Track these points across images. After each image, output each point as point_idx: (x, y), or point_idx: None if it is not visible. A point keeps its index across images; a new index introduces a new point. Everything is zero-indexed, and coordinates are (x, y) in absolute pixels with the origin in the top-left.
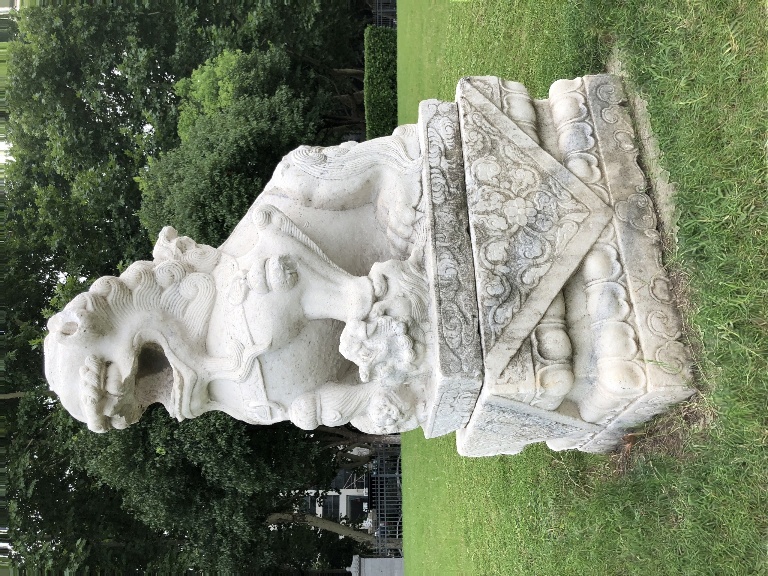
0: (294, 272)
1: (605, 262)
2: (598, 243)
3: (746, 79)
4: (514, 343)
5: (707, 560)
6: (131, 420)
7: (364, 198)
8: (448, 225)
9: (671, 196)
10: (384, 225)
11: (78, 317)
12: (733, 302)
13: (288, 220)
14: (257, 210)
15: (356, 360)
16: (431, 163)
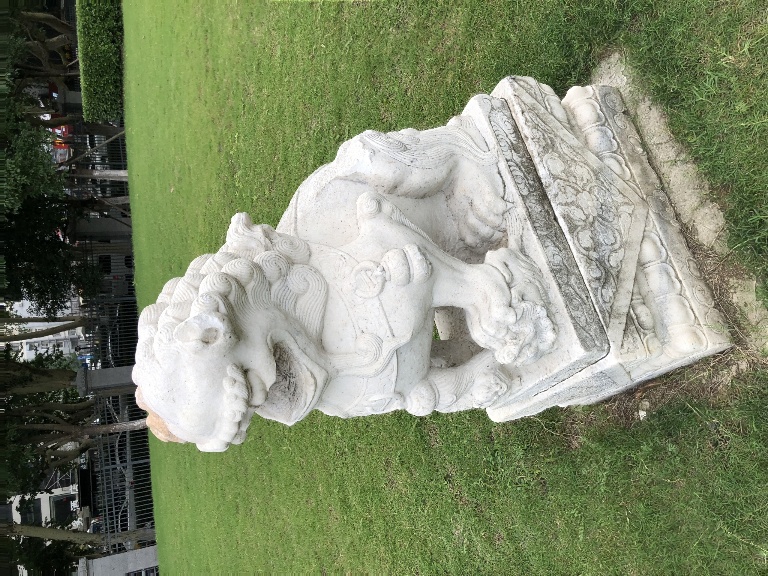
0: None
1: (655, 247)
2: (646, 231)
3: None
4: (622, 318)
5: None
6: None
7: (440, 186)
8: (540, 215)
9: (692, 193)
10: (459, 213)
11: (221, 322)
12: None
13: (397, 209)
14: (368, 198)
15: (495, 344)
16: (506, 156)
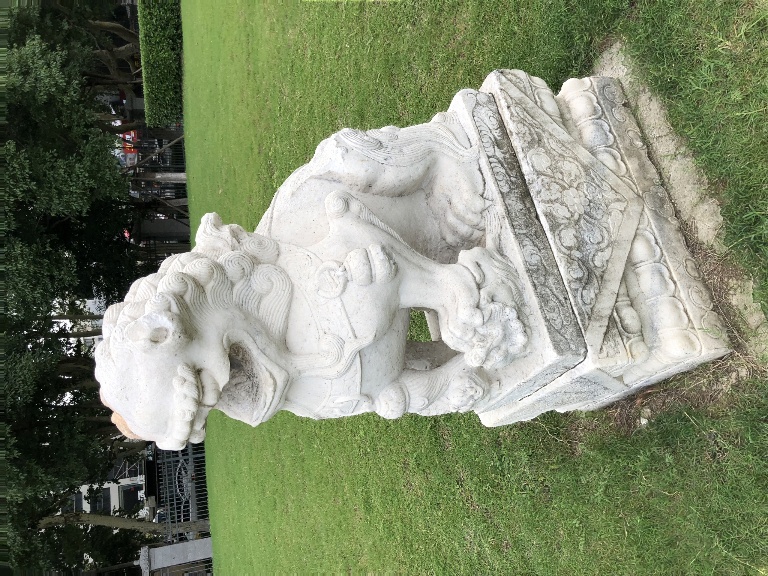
0: (395, 262)
1: (649, 246)
2: (639, 229)
3: None
4: (603, 321)
5: (766, 484)
6: None
7: (418, 185)
8: (520, 213)
9: (691, 189)
10: (439, 212)
11: (170, 321)
12: None
13: (366, 207)
14: (335, 197)
15: (463, 346)
16: (487, 152)
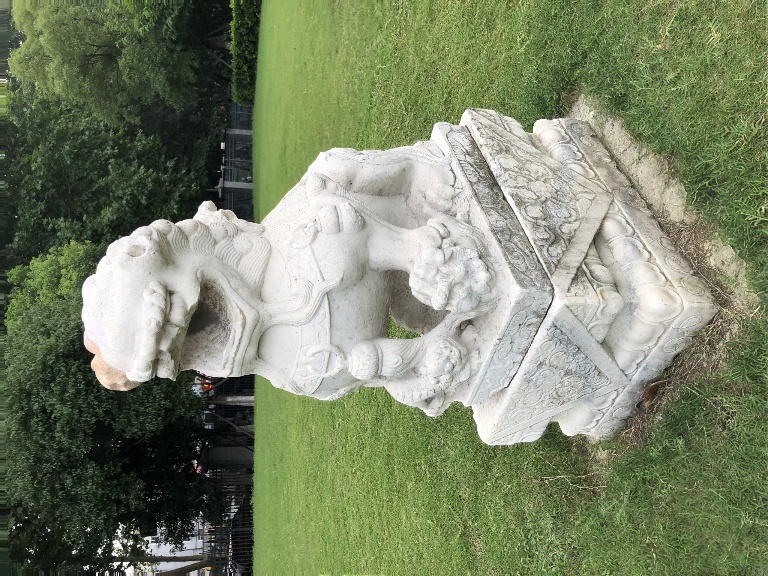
0: (362, 216)
1: (619, 225)
2: (609, 213)
3: (731, 51)
4: (571, 270)
5: None
6: (175, 371)
7: (397, 187)
8: (487, 195)
9: (657, 180)
10: (417, 209)
11: (147, 240)
12: (762, 191)
13: (342, 187)
14: (313, 176)
15: (429, 290)
16: (458, 158)
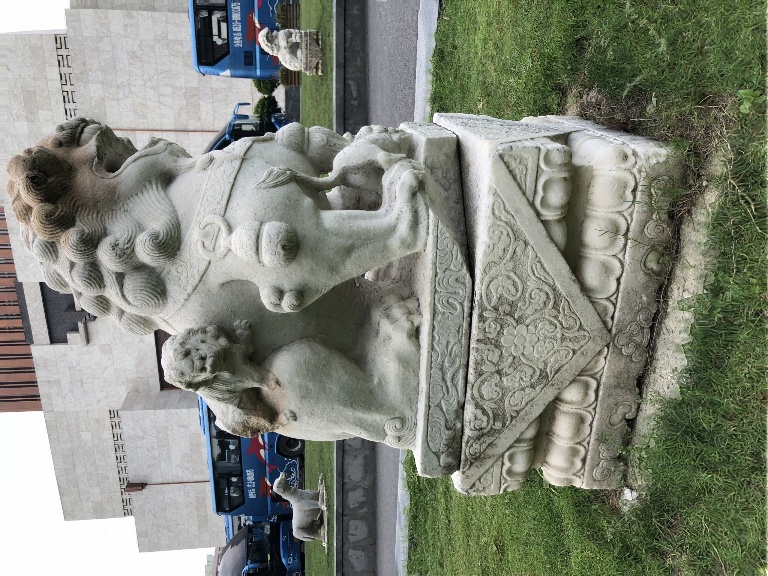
0: None
1: None
2: None
3: None
4: None
5: None
6: (102, 137)
7: None
8: None
9: None
10: None
11: None
12: None
13: None
14: None
15: None
16: None
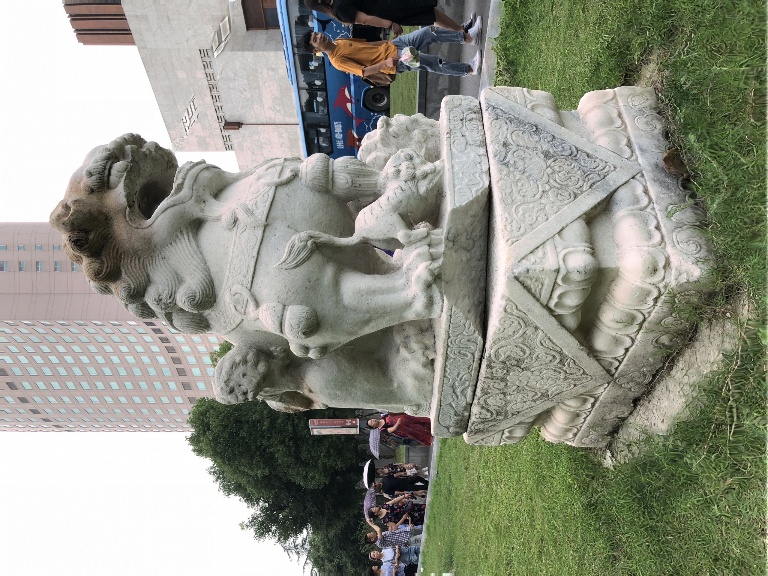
0: None
1: None
2: None
3: None
4: None
5: None
6: (129, 177)
7: None
8: None
9: None
10: (399, 255)
11: None
12: None
13: None
14: None
15: None
16: None
